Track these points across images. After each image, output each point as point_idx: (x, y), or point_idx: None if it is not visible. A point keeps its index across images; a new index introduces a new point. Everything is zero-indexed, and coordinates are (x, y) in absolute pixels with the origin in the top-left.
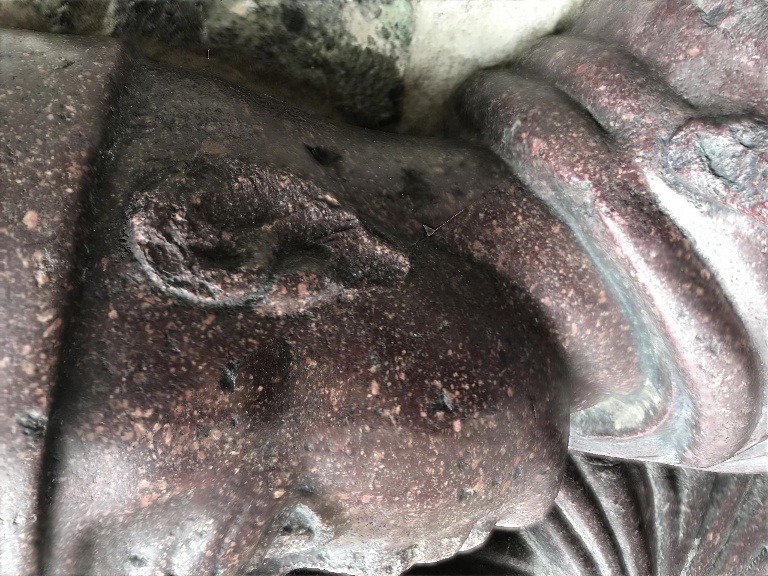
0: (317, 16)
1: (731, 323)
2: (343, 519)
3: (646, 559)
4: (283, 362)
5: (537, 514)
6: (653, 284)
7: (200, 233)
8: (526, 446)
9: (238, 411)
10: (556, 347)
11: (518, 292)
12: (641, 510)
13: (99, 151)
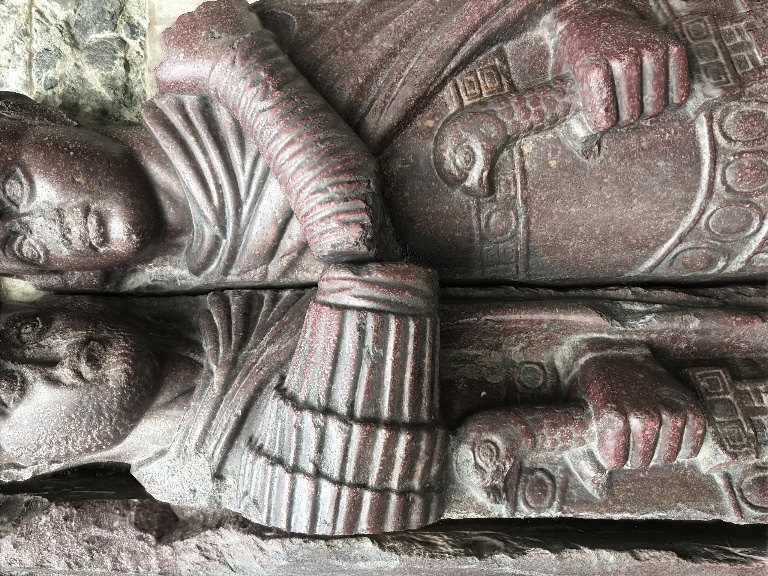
0: (112, 111)
1: (172, 129)
2: (32, 181)
3: (242, 326)
4: (23, 130)
5: (124, 222)
6: (148, 122)
7: (16, 108)
8: (104, 174)
9: (4, 134)
10: (137, 162)
11: (125, 145)
12: (251, 311)
13: (2, 96)
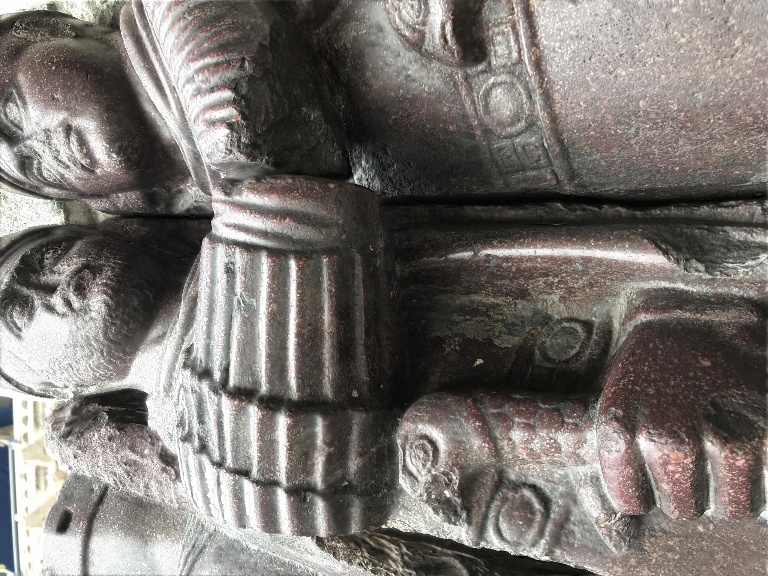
0: None
1: None
2: (25, 103)
3: None
4: (24, 49)
5: (101, 139)
6: None
7: (30, 26)
8: (81, 87)
9: (6, 55)
10: (122, 70)
11: None
12: None
13: (27, 16)
